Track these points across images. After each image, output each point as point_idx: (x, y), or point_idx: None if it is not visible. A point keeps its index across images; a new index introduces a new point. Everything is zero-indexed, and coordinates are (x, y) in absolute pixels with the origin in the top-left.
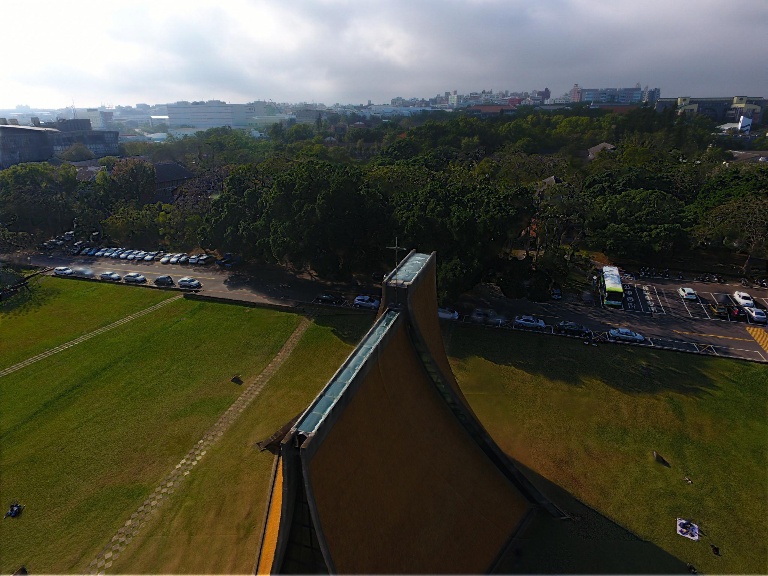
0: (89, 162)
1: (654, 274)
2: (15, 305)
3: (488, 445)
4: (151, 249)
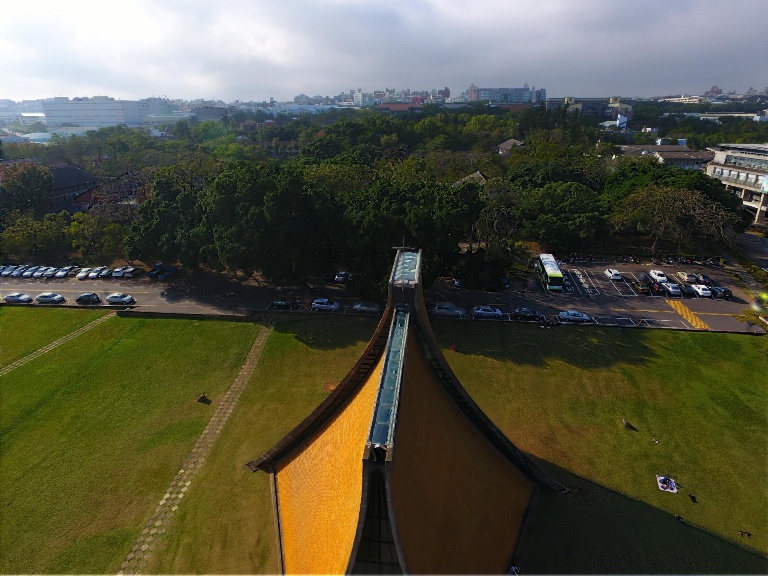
0: None
1: (582, 259)
2: None
3: (494, 433)
4: (61, 264)
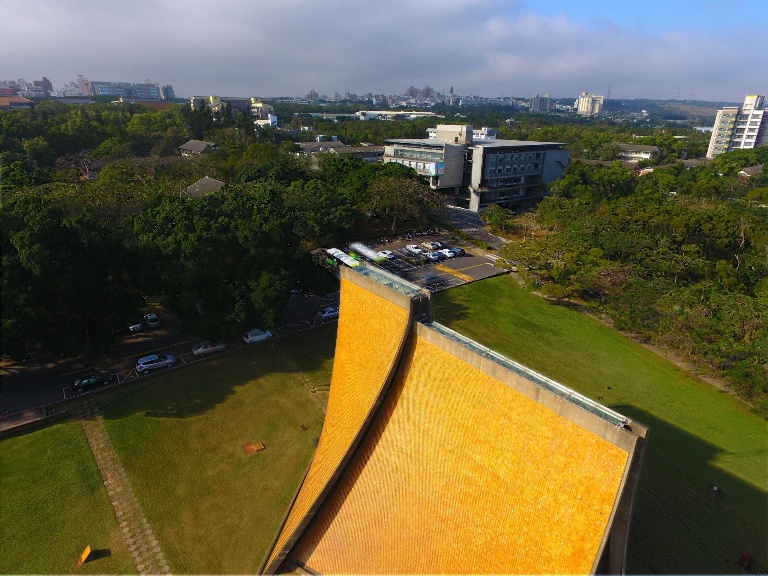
0: None
1: (352, 247)
2: None
3: None
4: None
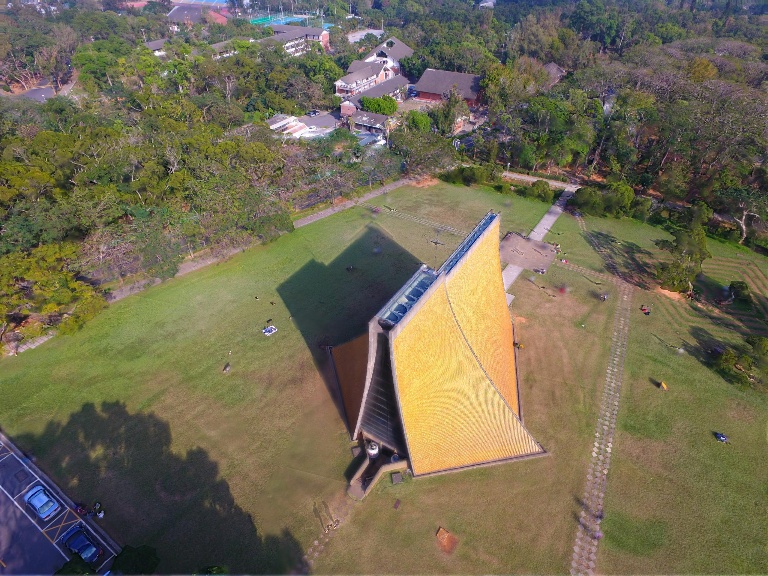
0: None
1: None
2: None
3: None
4: None
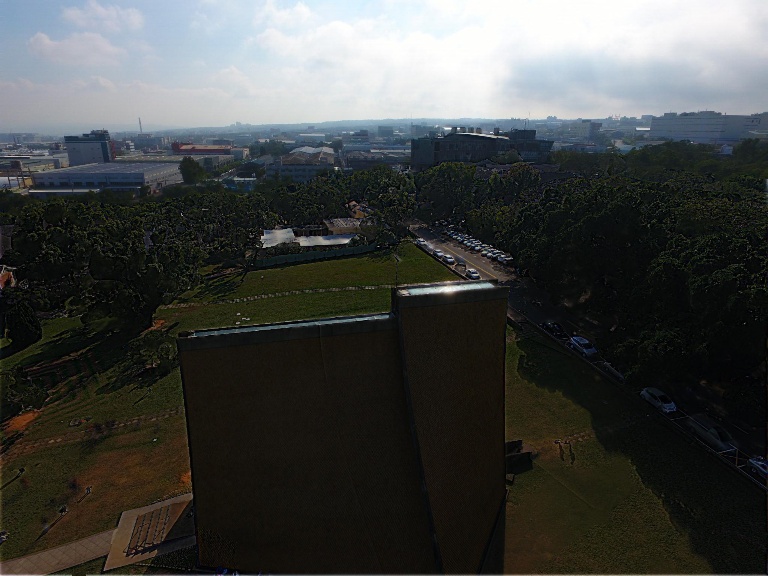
0: (508, 166)
1: None
2: (380, 255)
3: None
4: (490, 242)
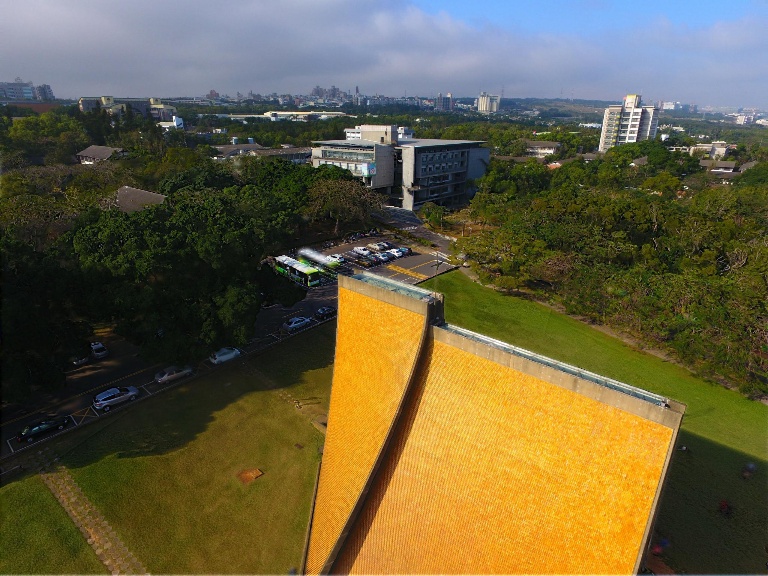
0: None
1: (299, 253)
2: None
3: None
4: None
